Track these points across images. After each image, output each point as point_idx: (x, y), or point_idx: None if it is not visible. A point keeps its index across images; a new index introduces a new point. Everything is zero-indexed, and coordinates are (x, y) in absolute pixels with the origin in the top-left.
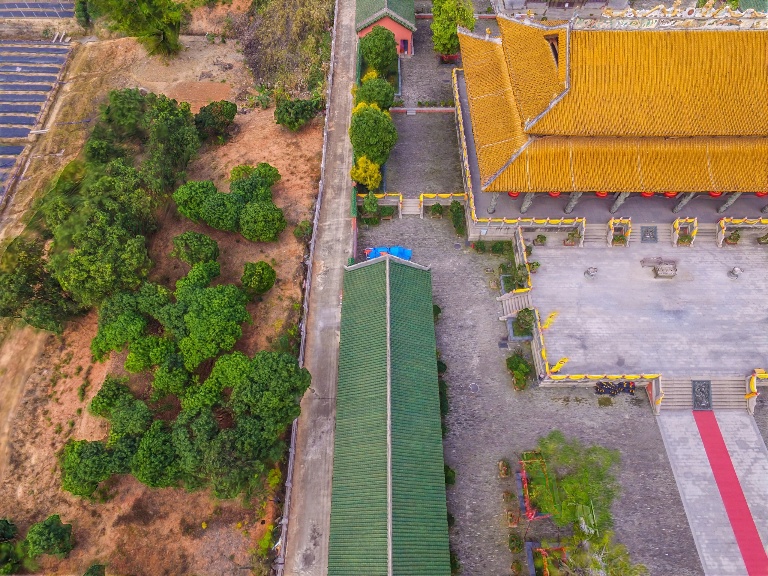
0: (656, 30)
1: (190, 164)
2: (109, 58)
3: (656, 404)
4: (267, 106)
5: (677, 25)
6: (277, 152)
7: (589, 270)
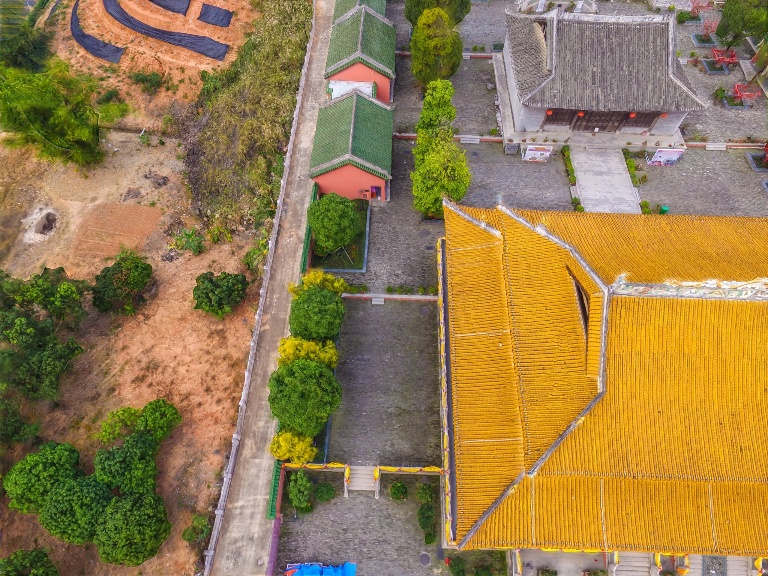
0: (750, 299)
1: (79, 356)
2: (21, 159)
3: None
4: (200, 251)
5: None
6: (194, 348)
7: None
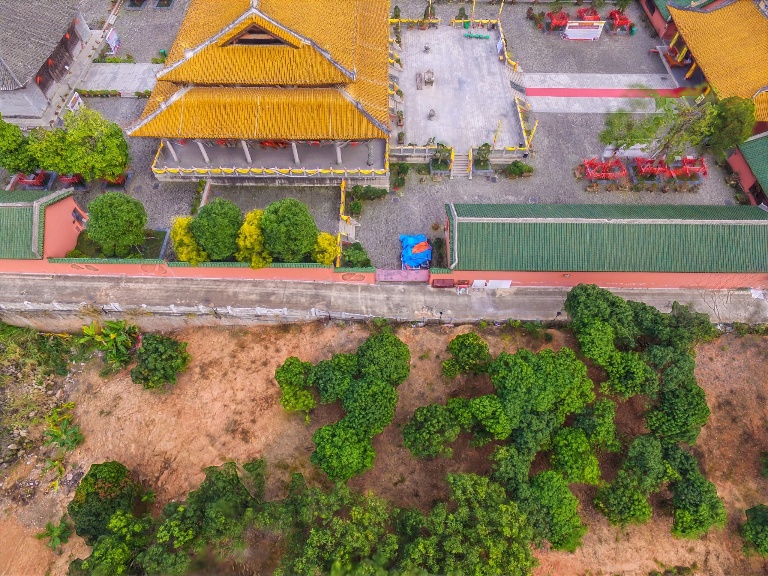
0: None
1: None
2: None
3: (528, 108)
4: None
5: None
6: (217, 390)
7: (431, 114)
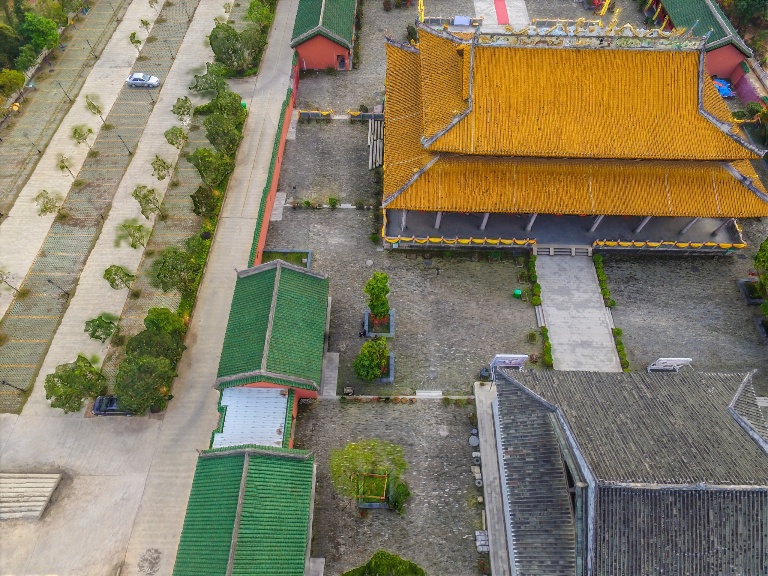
0: None
1: None
2: None
3: None
4: None
5: (593, 43)
6: None
7: None
